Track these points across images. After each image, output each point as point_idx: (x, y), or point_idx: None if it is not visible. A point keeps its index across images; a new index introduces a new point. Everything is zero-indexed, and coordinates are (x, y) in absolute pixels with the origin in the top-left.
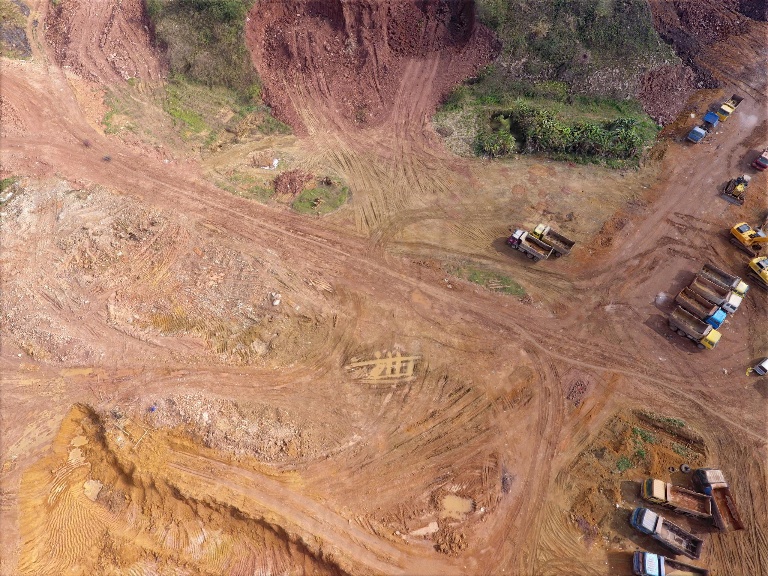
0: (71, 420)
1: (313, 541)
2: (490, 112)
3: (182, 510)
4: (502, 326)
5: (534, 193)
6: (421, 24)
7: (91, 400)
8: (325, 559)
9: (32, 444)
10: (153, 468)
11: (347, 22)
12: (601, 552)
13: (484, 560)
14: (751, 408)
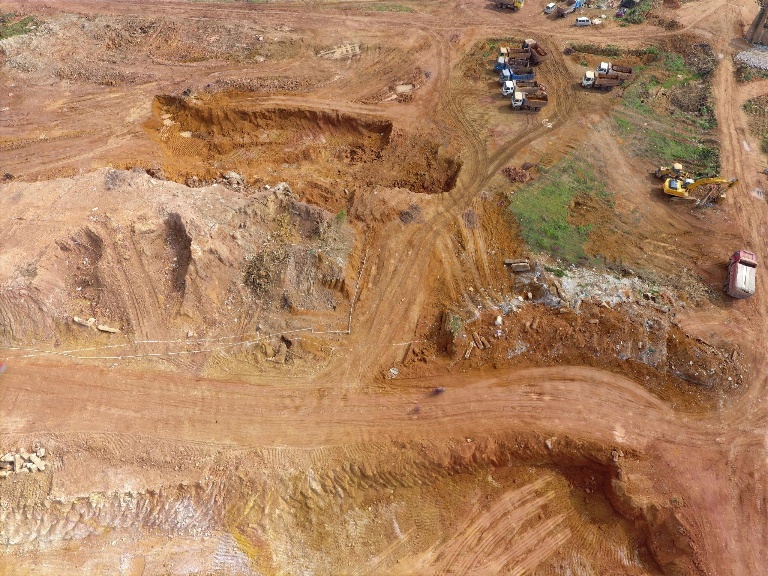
0: (156, 106)
1: (331, 111)
2: None
3: (248, 127)
4: (404, 23)
5: None
6: None
7: (165, 93)
8: (341, 118)
9: (139, 115)
10: None
11: None
12: (483, 85)
13: (425, 100)
14: (546, 25)
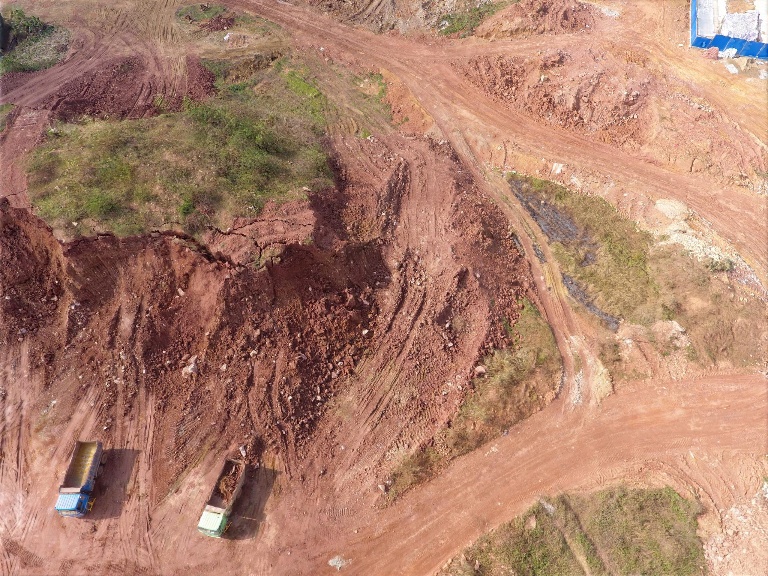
0: None
1: None
2: None
3: None
4: None
5: (39, 2)
6: None
7: None
8: None
9: None
10: None
11: None
12: None
13: None
14: None
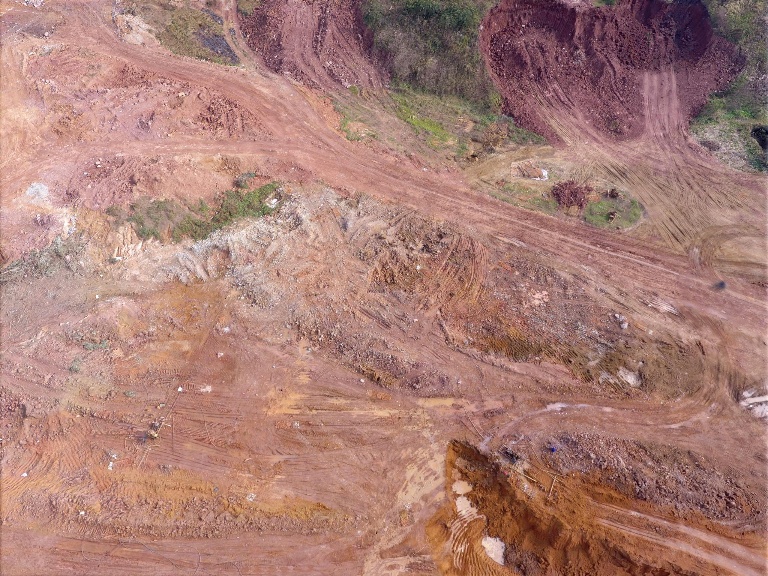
0: (448, 461)
1: None
2: (751, 126)
3: None
4: None
5: None
6: (649, 37)
7: (469, 437)
8: None
9: (422, 490)
10: (585, 525)
11: (576, 33)
12: None
13: None
14: None
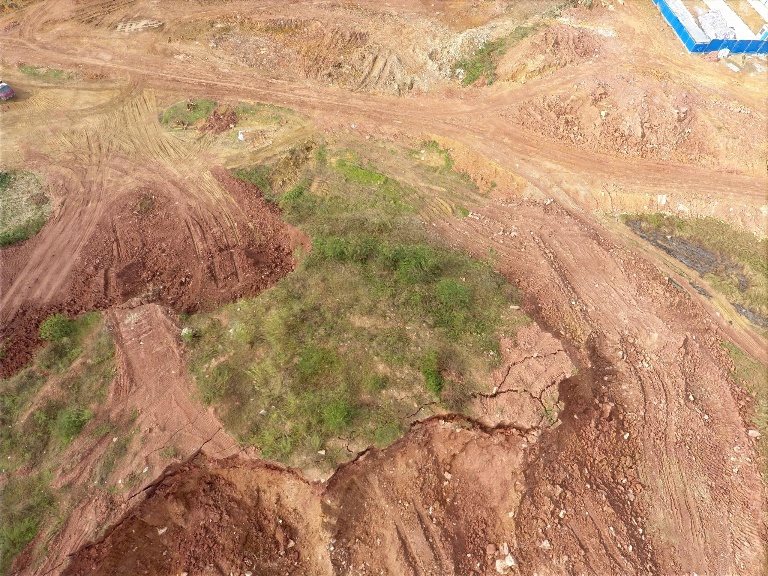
0: None
1: None
2: None
3: None
4: (47, 49)
5: None
6: None
7: None
8: None
9: None
10: None
11: None
12: None
13: None
14: None
